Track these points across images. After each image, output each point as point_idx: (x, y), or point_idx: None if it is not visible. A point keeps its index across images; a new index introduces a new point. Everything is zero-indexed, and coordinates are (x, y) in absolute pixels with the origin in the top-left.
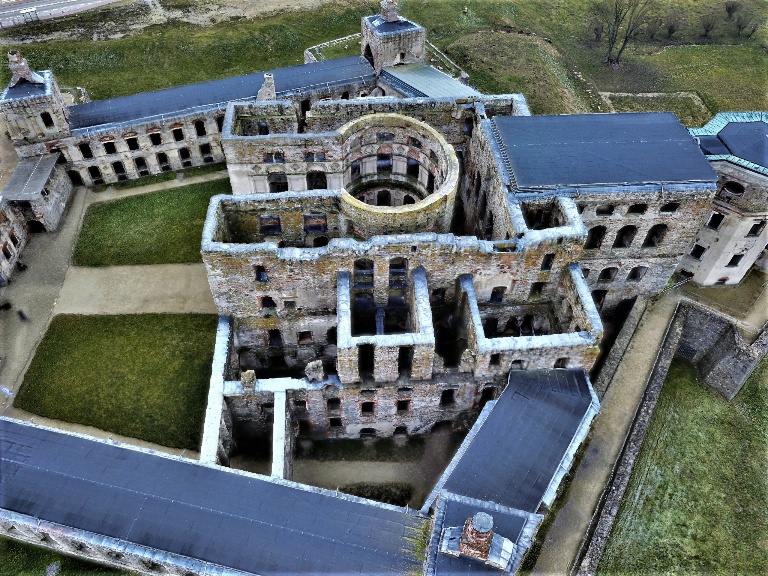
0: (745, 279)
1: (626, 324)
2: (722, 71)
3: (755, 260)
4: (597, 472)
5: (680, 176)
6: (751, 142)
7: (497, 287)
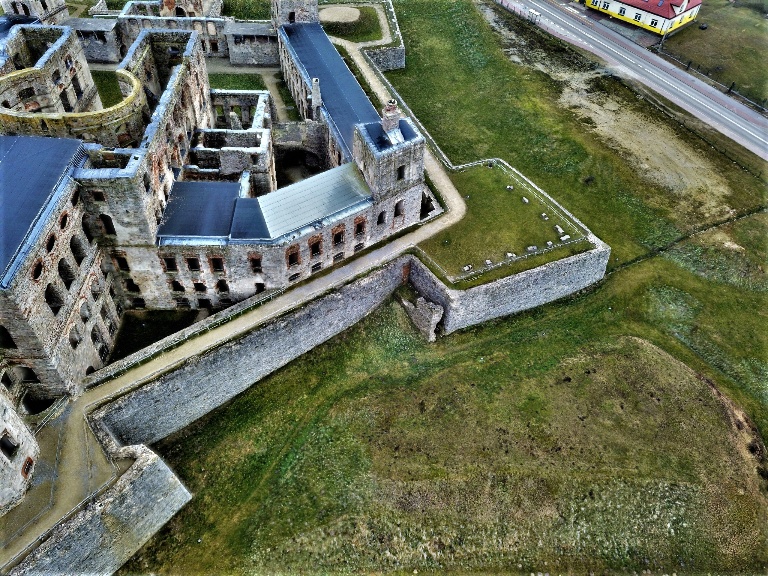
0: None
1: None
2: None
3: None
4: None
5: None
6: None
7: None
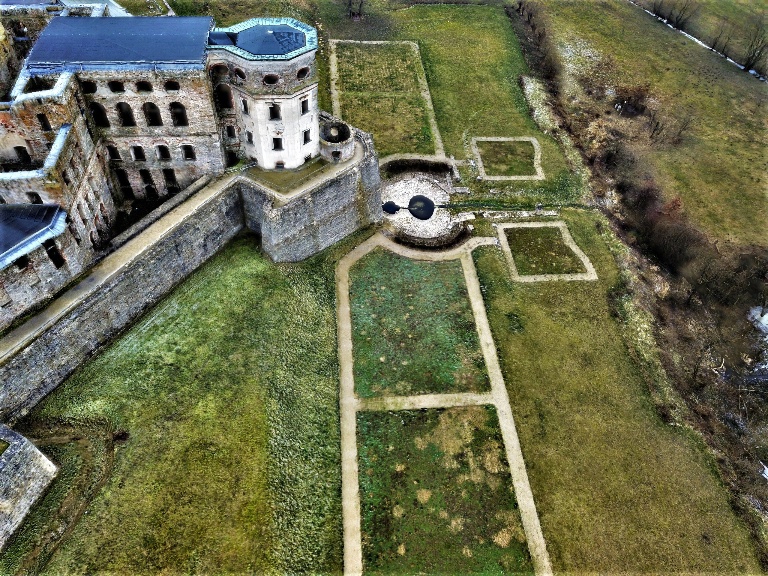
0: (309, 166)
1: (178, 194)
2: (452, 25)
3: (319, 150)
4: (82, 293)
5: (171, 57)
6: (255, 36)
7: (17, 147)
